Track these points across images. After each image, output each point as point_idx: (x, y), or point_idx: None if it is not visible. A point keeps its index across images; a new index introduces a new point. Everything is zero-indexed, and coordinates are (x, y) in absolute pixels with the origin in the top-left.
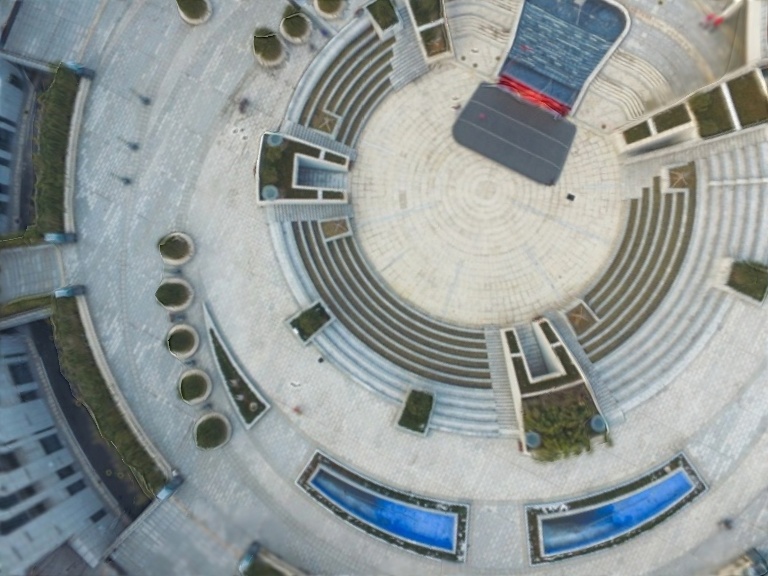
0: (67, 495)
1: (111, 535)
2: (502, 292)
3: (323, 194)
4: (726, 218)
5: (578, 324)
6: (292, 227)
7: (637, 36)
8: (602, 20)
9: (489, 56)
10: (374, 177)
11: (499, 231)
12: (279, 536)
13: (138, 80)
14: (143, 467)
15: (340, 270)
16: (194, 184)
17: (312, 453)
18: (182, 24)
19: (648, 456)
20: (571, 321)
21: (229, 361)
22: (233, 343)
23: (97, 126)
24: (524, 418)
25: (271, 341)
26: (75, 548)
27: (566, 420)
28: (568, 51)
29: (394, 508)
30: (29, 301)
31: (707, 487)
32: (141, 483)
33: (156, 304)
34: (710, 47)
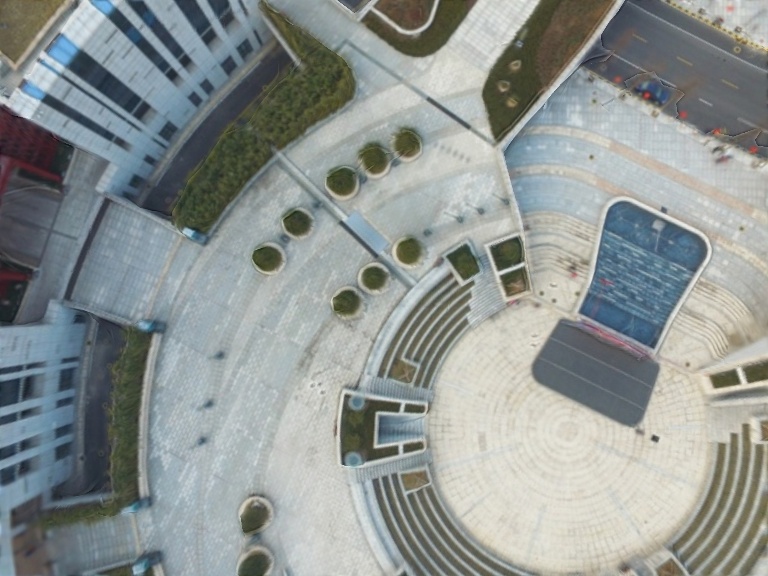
0: None
1: None
2: (586, 538)
3: (404, 448)
4: None
5: None
6: (373, 485)
7: (718, 264)
8: (681, 246)
9: (568, 291)
10: (452, 418)
11: (582, 474)
12: None
13: (211, 332)
14: None
15: (421, 524)
16: (271, 442)
17: None
18: (255, 273)
19: None
20: None
21: None
22: None
23: (169, 381)
24: None
25: None
26: None
27: None
28: (649, 283)
29: None
30: (105, 573)
31: None
32: None
33: (236, 574)
34: None
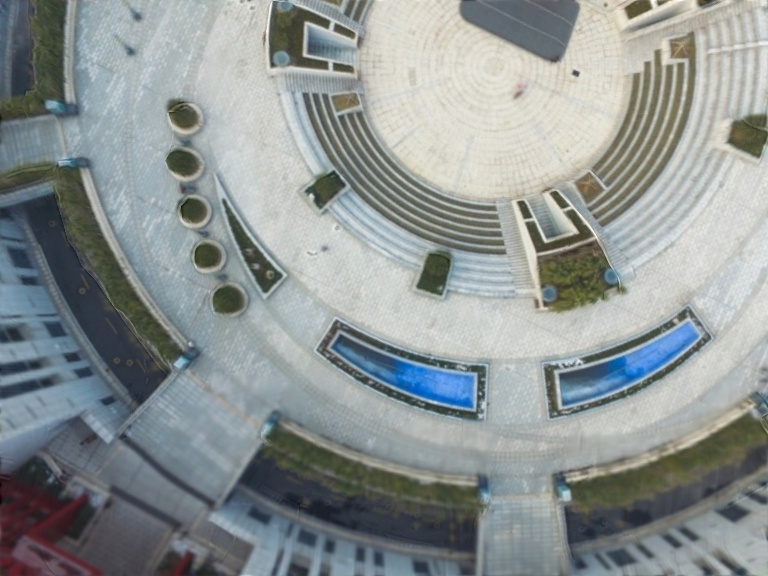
0: (76, 376)
1: (125, 413)
2: (512, 167)
3: (334, 66)
4: (725, 83)
5: (587, 191)
6: (303, 98)
7: None
8: None
9: None
10: (383, 54)
11: (507, 107)
12: (300, 404)
13: None
14: (157, 339)
15: (352, 144)
16: (201, 55)
17: (331, 320)
18: None
19: (657, 310)
20: (580, 189)
21: (243, 231)
22: (247, 214)
23: None
24: (540, 274)
25: (286, 211)
26: (88, 423)
27: (582, 269)
28: None
29: (414, 371)
30: (29, 173)
31: (713, 337)
32: (155, 357)
33: (165, 175)
34: None
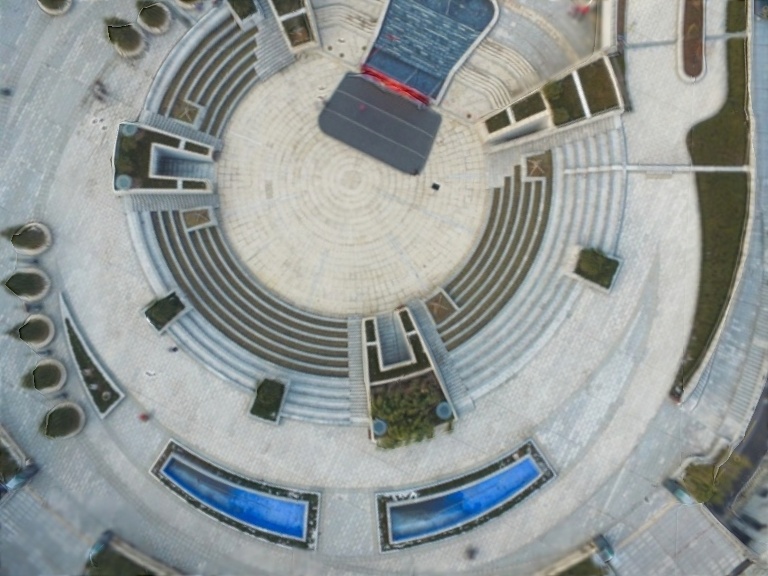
0: None
1: None
2: (367, 281)
3: (183, 184)
4: (579, 206)
5: (436, 313)
6: (151, 217)
7: (506, 25)
8: (472, 10)
9: (355, 46)
10: (240, 167)
11: (364, 221)
12: (133, 525)
13: None
14: None
15: (202, 260)
16: (53, 174)
17: (166, 442)
18: (42, 14)
19: (497, 443)
20: (430, 310)
21: (84, 351)
22: (89, 333)
23: None
24: (371, 406)
25: (127, 331)
26: None
27: (407, 407)
28: (435, 41)
29: (247, 496)
30: None
31: (555, 474)
32: None
33: (12, 294)
34: (578, 36)
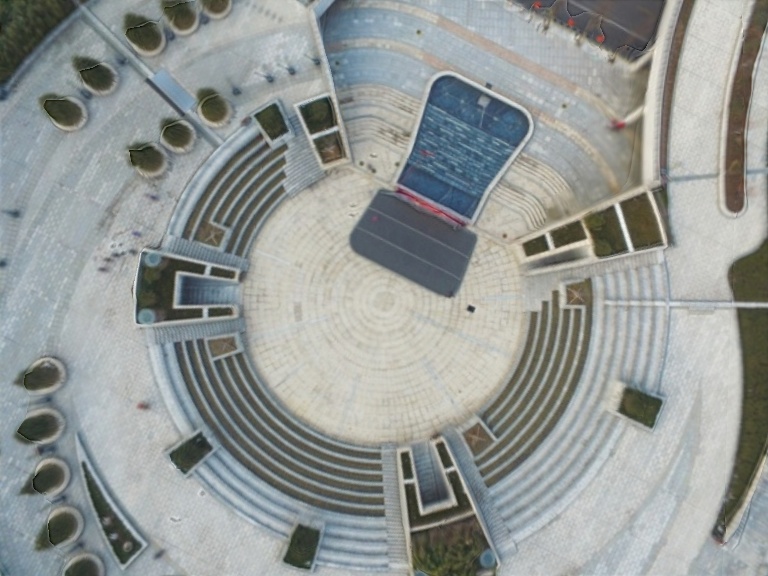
0: None
1: None
2: (400, 408)
3: (209, 312)
4: (620, 339)
5: (474, 445)
6: (174, 348)
7: (540, 140)
8: (506, 123)
9: (388, 161)
10: (267, 288)
11: (398, 344)
12: None
13: (6, 190)
14: None
15: (228, 391)
16: (67, 303)
17: None
18: (55, 130)
19: None
20: (468, 442)
21: (103, 496)
22: (108, 476)
23: None
24: (412, 554)
25: (150, 473)
26: None
27: (452, 561)
28: (470, 156)
29: None
30: None
31: None
32: None
33: (23, 436)
34: (613, 152)
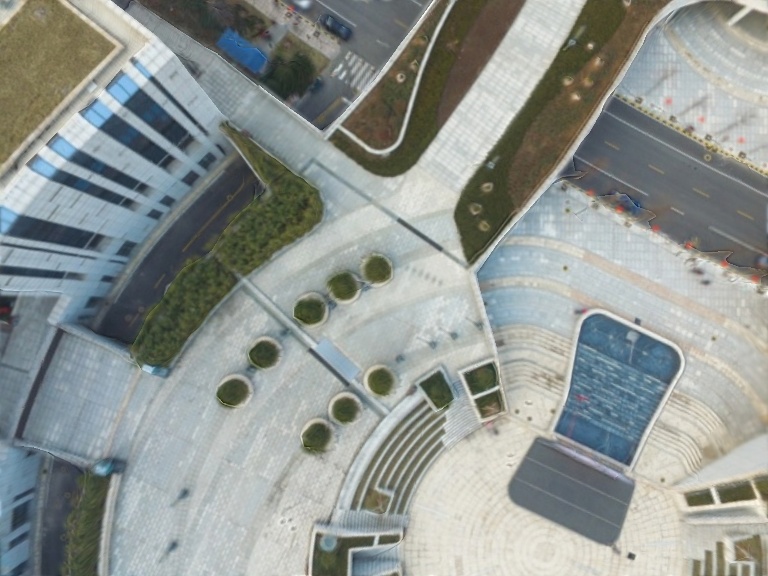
0: None
1: None
2: None
3: None
4: None
5: None
6: None
7: (691, 375)
8: (655, 357)
9: (544, 409)
10: (428, 543)
11: None
12: None
13: (174, 469)
14: None
15: None
16: None
17: None
18: (221, 406)
19: None
20: None
21: None
22: None
23: (131, 522)
24: None
25: None
26: None
27: None
28: (623, 397)
29: None
30: None
31: None
32: None
33: None
34: (764, 385)
